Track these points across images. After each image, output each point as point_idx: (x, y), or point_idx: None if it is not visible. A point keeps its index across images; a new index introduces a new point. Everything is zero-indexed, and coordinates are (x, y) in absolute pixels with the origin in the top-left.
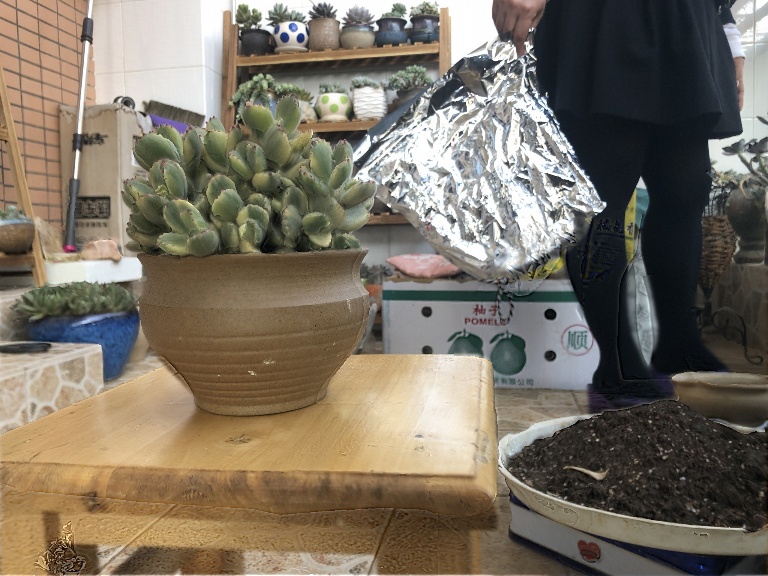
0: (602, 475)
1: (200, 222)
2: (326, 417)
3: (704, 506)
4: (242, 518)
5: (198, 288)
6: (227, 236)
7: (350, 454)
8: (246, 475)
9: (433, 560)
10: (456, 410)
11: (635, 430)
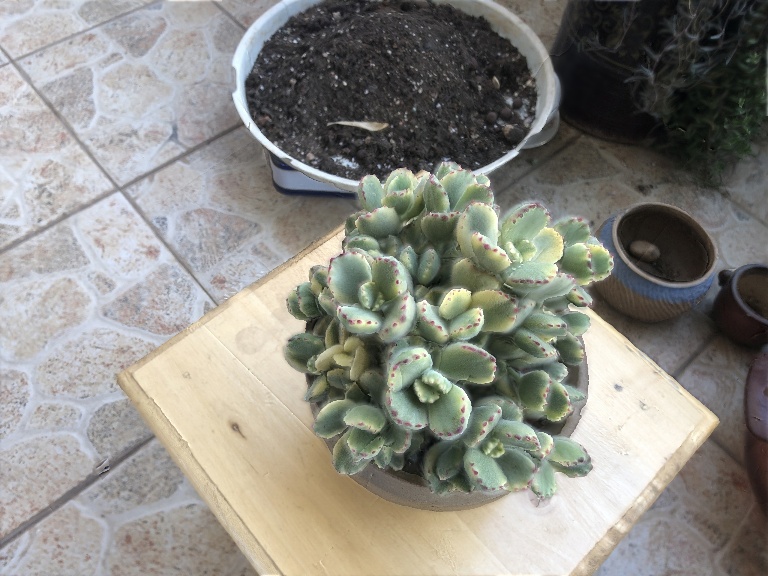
0: (374, 125)
1: None
2: None
3: (459, 123)
4: (11, 341)
5: None
6: (539, 413)
7: (629, 451)
8: (617, 530)
9: (253, 260)
10: None
11: (379, 65)
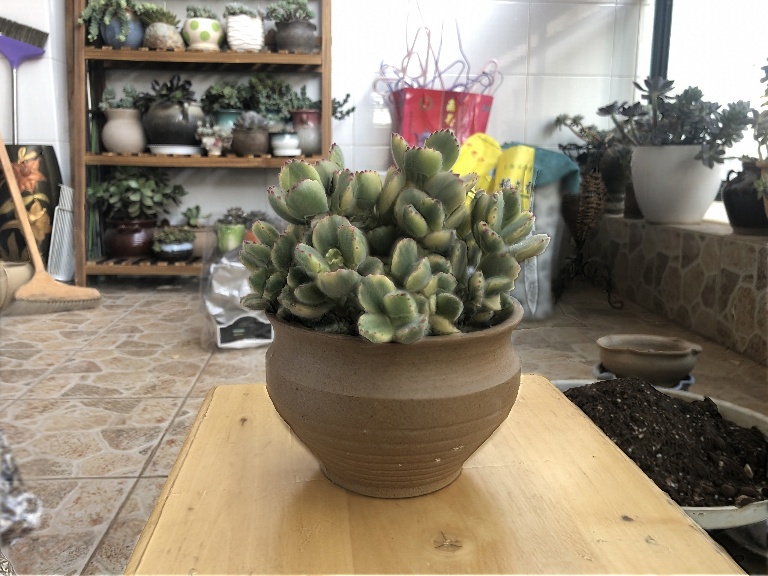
0: None
1: (415, 307)
2: (498, 492)
3: (681, 480)
4: None
5: (389, 374)
6: None
7: (596, 558)
8: None
9: None
10: (617, 470)
11: (606, 409)
